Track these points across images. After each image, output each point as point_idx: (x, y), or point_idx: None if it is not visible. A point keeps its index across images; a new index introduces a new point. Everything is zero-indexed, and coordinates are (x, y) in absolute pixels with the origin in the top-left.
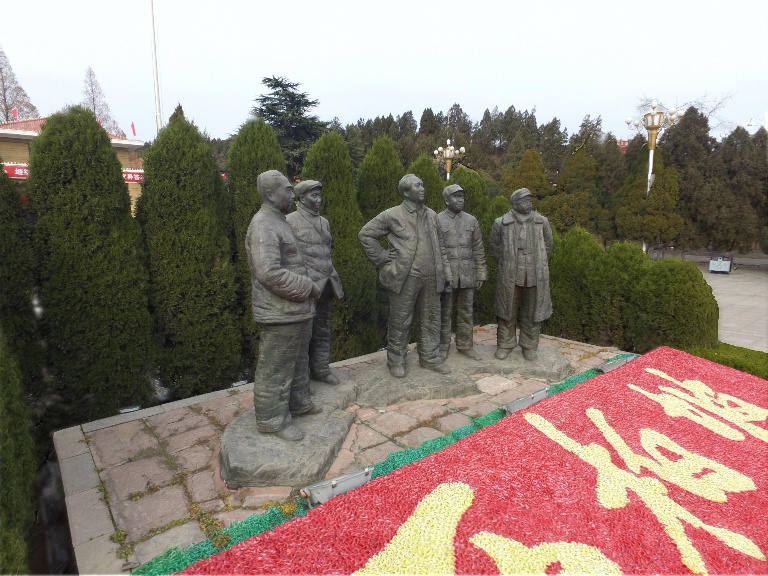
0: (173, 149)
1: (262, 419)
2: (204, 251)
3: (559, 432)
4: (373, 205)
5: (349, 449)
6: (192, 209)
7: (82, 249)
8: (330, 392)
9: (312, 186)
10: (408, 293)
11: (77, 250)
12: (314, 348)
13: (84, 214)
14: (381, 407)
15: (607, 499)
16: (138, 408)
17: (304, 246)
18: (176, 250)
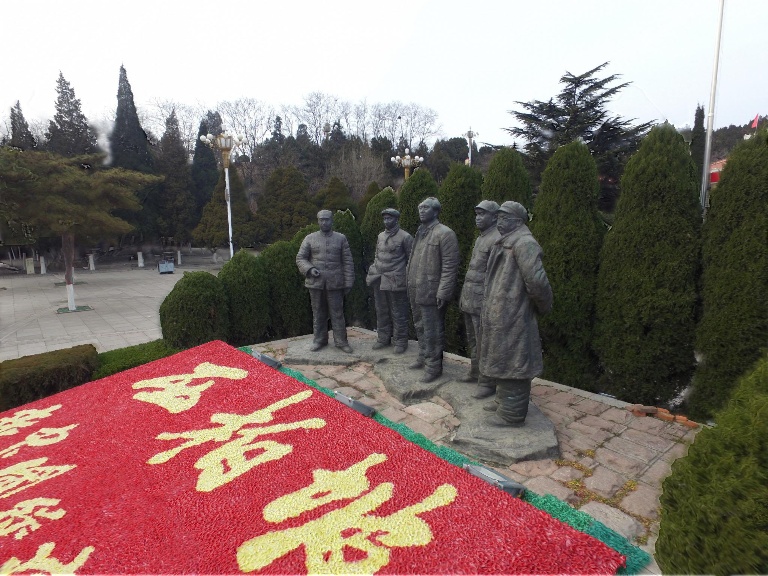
0: None
1: None
2: None
3: None
4: None
5: (315, 367)
6: None
7: None
8: (380, 353)
9: None
10: None
11: None
12: (393, 324)
13: None
14: (372, 372)
15: (219, 416)
16: None
17: (378, 252)
18: None
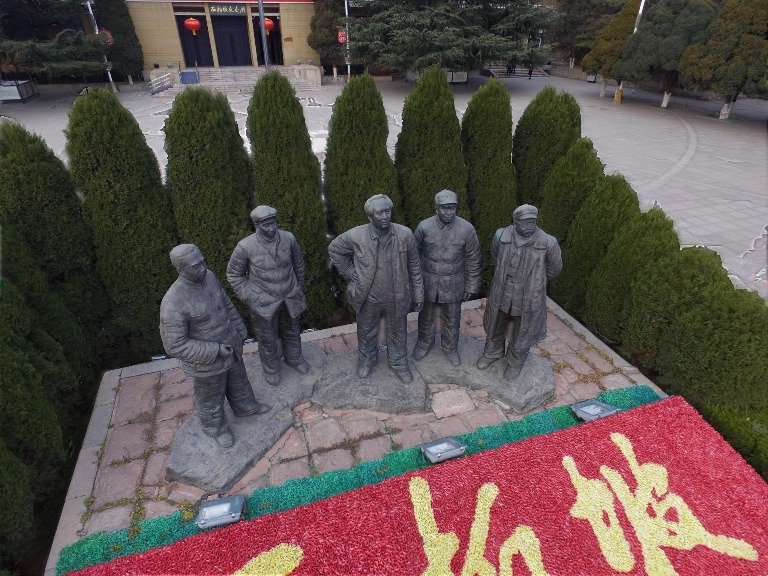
0: (184, 124)
1: (203, 426)
2: (219, 222)
3: (430, 509)
4: (412, 153)
5: (269, 459)
6: (206, 183)
7: (115, 227)
8: (293, 384)
9: (262, 218)
10: (367, 314)
11: (111, 228)
12: (285, 343)
13: (111, 198)
14: (328, 409)
15: None
16: (165, 356)
17: (259, 271)
18: (195, 222)
